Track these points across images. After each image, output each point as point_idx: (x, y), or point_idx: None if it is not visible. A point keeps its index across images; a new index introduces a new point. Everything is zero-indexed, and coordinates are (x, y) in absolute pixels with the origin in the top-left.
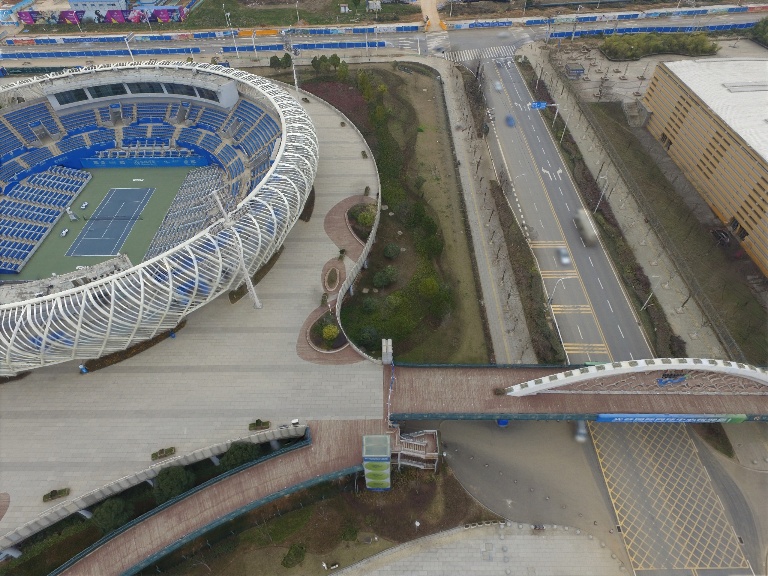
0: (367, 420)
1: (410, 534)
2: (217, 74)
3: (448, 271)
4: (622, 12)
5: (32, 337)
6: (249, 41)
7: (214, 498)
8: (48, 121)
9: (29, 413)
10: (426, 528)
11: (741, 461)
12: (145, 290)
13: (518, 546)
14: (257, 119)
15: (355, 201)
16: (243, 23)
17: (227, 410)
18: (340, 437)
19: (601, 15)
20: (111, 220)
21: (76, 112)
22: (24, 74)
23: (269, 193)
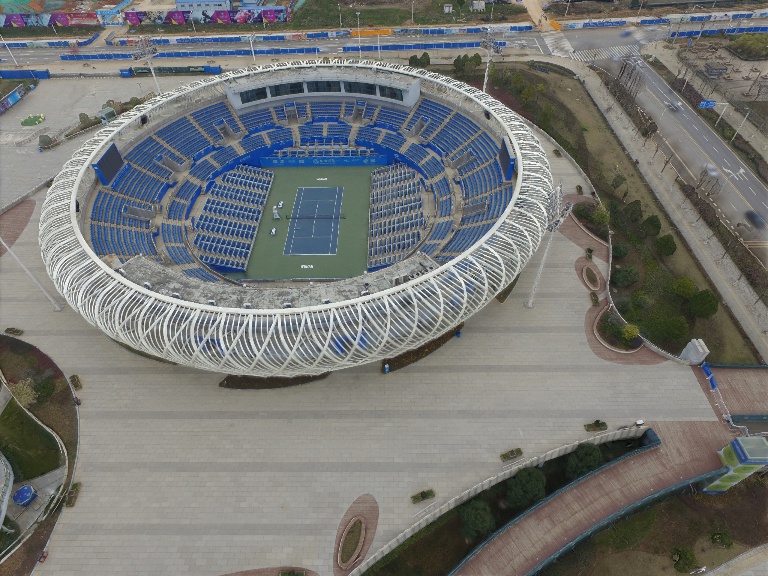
0: (703, 421)
1: (761, 538)
2: (399, 73)
3: (676, 271)
4: (731, 12)
5: (376, 336)
6: (363, 41)
7: (580, 500)
8: (229, 120)
9: (350, 413)
10: None
11: None
12: (466, 288)
13: None
14: (446, 118)
15: (572, 200)
16: (350, 23)
17: (552, 411)
18: (684, 439)
19: None
20: (314, 219)
21: (253, 111)
22: (150, 74)
23: (533, 191)
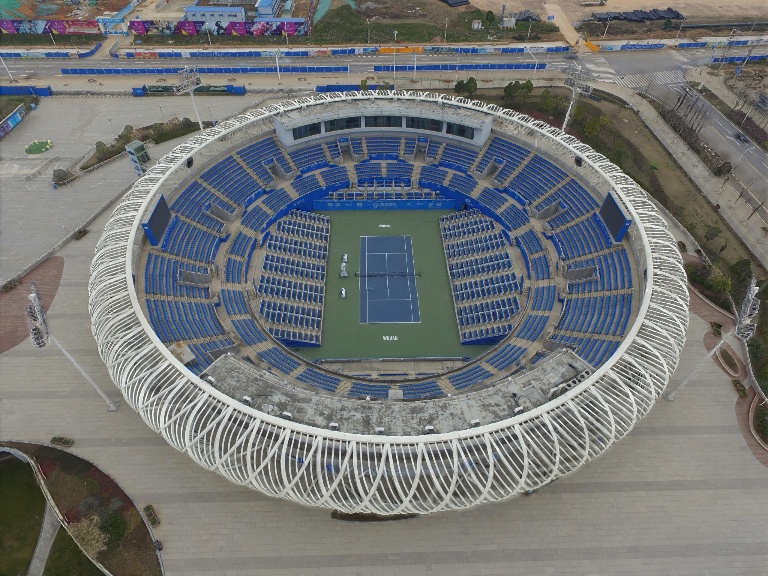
0: None
1: None
2: (469, 108)
3: None
4: (765, 36)
5: (544, 470)
6: (393, 59)
7: None
8: (279, 158)
9: (500, 553)
10: None
11: None
12: (634, 400)
13: None
14: (523, 160)
15: None
16: (376, 39)
17: (736, 544)
18: None
19: (746, 38)
20: (386, 276)
21: (304, 147)
22: (166, 93)
23: (668, 264)
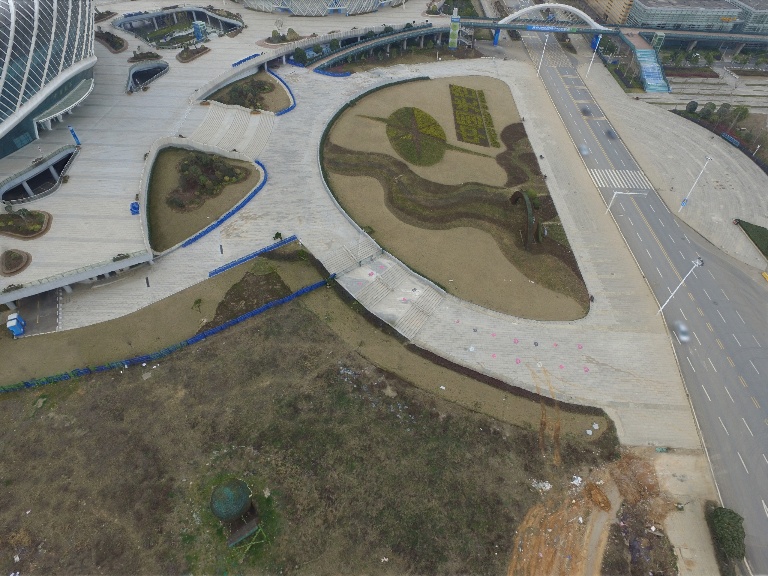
0: None
1: (463, 57)
2: None
3: None
4: None
5: None
6: None
7: None
8: None
9: None
10: (469, 56)
11: (579, 54)
12: None
13: (499, 61)
14: None
15: None
16: None
17: (401, 22)
18: (441, 26)
19: None
20: None
21: None
22: None
23: None
